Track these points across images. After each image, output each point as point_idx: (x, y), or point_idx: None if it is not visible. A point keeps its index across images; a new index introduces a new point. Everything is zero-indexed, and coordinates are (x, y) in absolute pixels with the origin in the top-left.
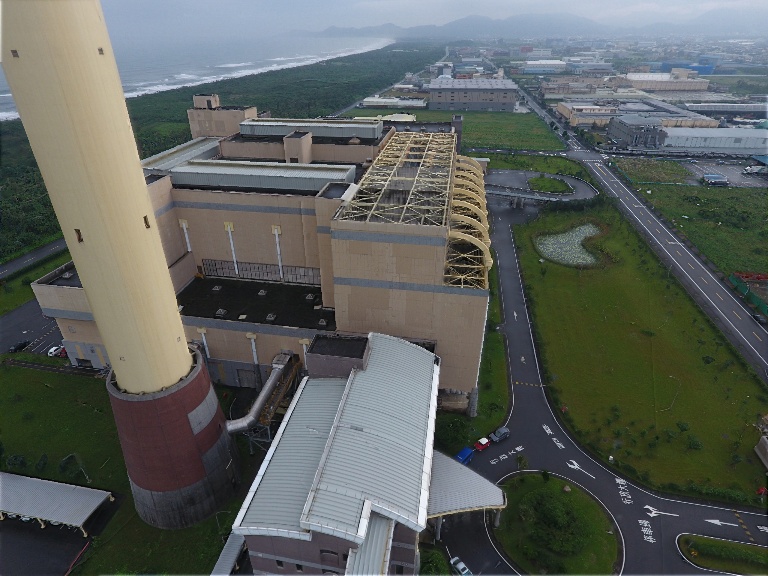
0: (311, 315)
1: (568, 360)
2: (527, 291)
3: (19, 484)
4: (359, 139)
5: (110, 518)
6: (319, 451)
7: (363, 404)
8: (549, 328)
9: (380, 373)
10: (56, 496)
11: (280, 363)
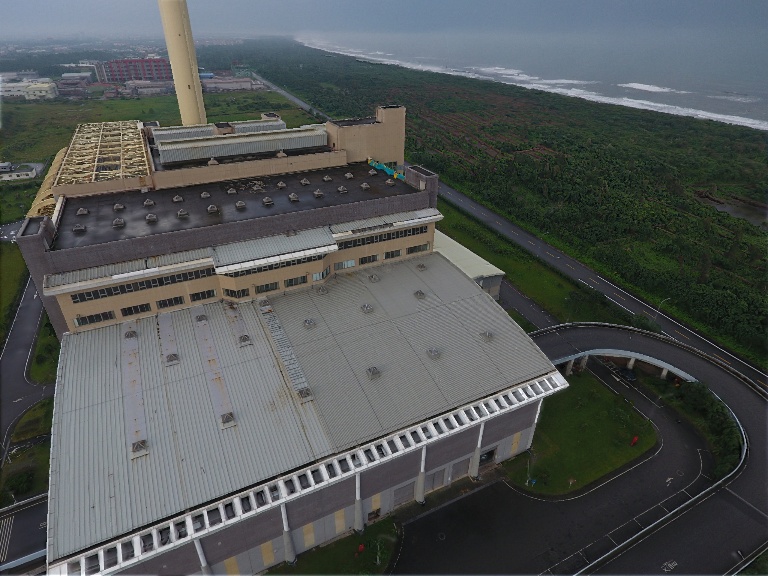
0: None
1: (5, 275)
2: (8, 322)
3: None
4: None
5: None
6: None
7: None
8: (6, 293)
9: None
10: None
11: None
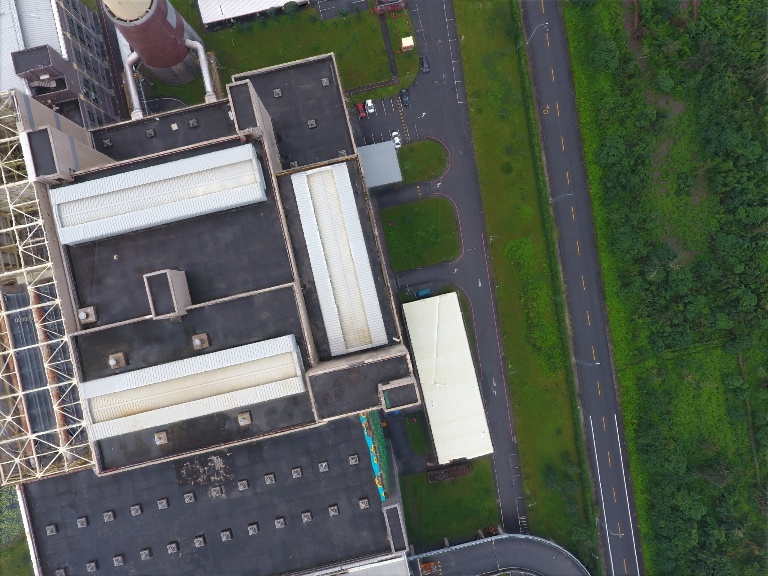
0: (123, 151)
1: None
2: None
3: (256, 4)
4: (113, 371)
5: (200, 19)
6: (23, 4)
7: (6, 31)
8: None
9: (8, 61)
10: (227, 7)
11: (135, 113)
